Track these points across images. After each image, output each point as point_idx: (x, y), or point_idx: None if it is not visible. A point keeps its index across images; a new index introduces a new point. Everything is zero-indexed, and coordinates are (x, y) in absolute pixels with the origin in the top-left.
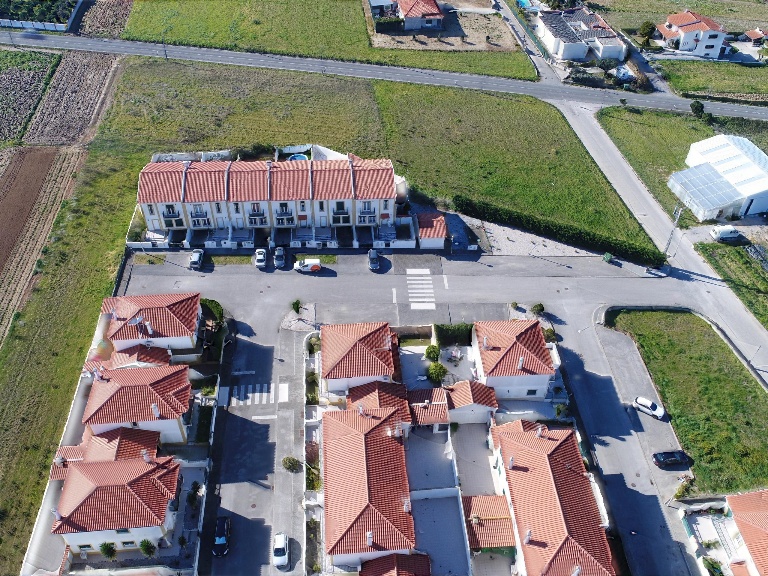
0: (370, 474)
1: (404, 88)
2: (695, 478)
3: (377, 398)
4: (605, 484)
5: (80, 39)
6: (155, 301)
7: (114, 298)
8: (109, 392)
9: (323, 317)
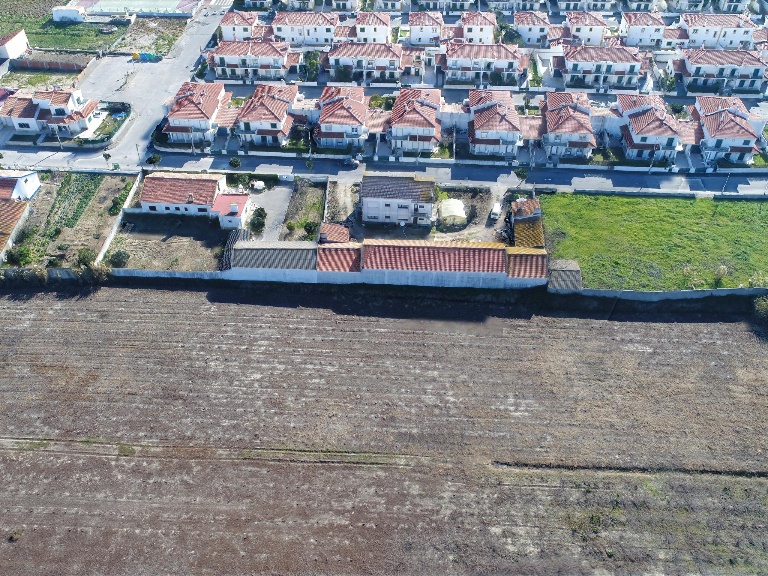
0: (717, 16)
1: None
2: (767, 124)
3: (763, 30)
4: (751, 102)
5: None
6: None
7: None
8: None
9: None
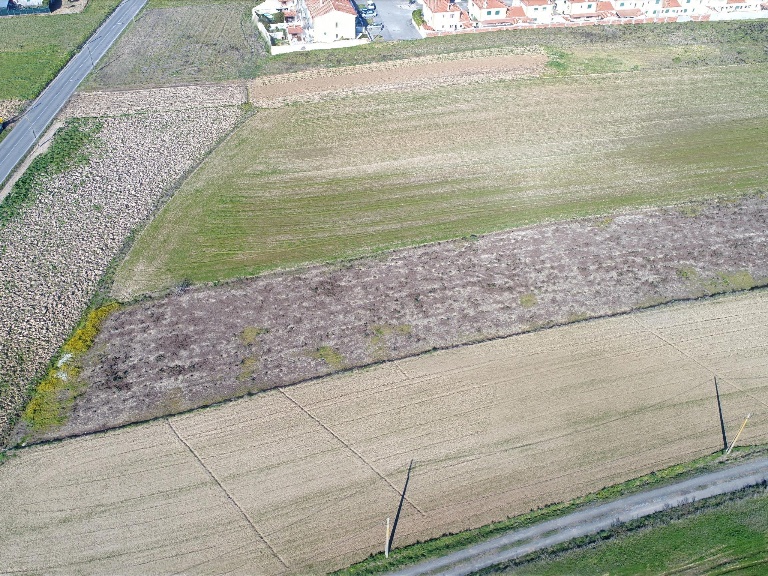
0: None
1: (158, 2)
2: None
3: None
4: None
5: (26, 119)
6: (435, 2)
7: (424, 27)
8: (493, 1)
9: (405, 3)
